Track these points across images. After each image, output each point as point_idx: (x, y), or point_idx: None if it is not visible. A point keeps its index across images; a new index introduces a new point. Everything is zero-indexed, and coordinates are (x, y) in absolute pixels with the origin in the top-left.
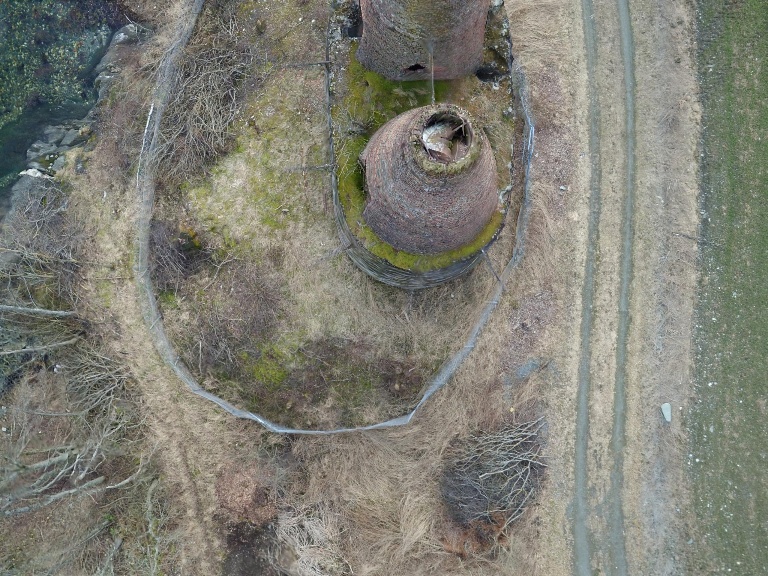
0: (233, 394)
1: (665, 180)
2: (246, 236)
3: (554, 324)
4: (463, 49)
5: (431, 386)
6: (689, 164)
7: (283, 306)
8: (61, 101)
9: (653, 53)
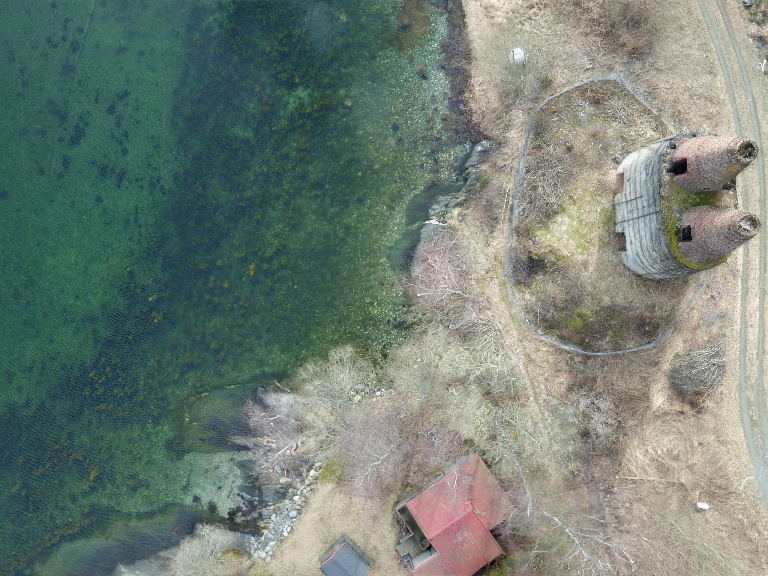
0: (554, 336)
1: None
2: (569, 254)
3: (728, 295)
4: None
5: (664, 328)
6: None
7: (589, 289)
8: (445, 183)
9: None
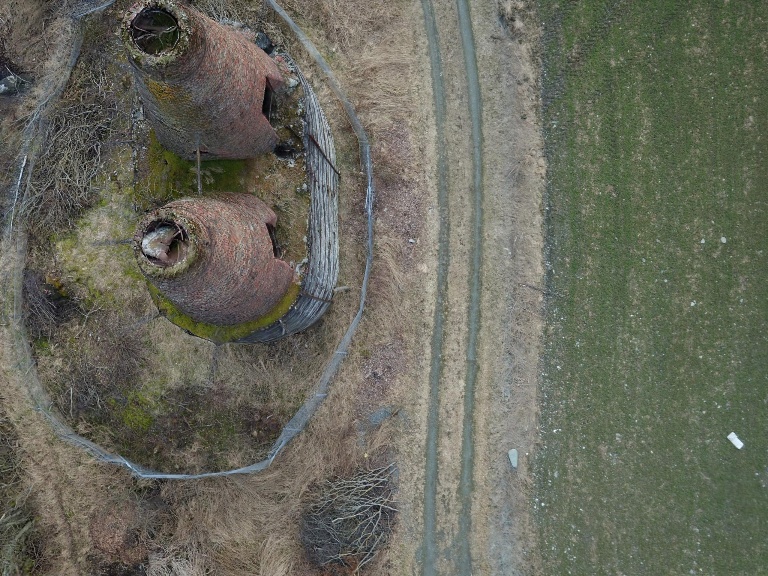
0: (105, 438)
1: (512, 232)
2: (109, 287)
3: (404, 373)
4: (239, 136)
5: (289, 432)
6: (535, 217)
7: (145, 355)
8: None
9: (500, 109)
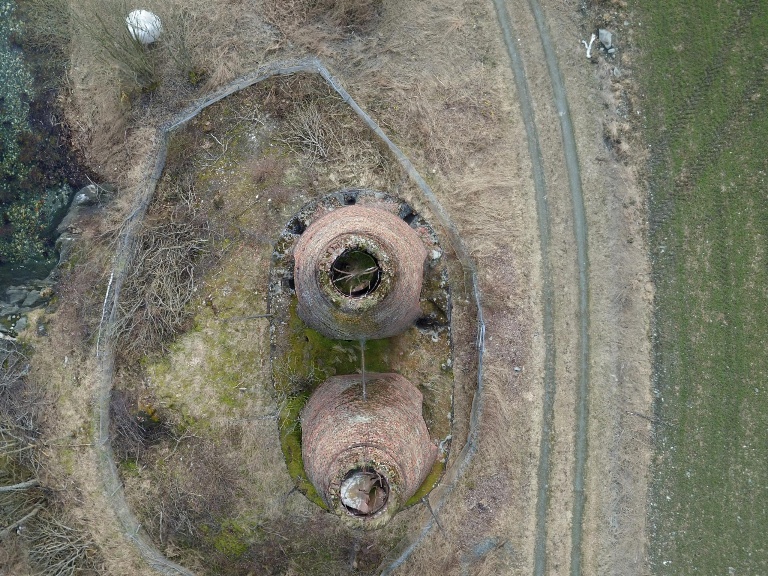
0: (194, 562)
1: (619, 359)
2: (204, 415)
3: (510, 504)
4: (396, 328)
5: (389, 562)
6: (642, 344)
7: (241, 485)
8: (23, 260)
9: (606, 233)
